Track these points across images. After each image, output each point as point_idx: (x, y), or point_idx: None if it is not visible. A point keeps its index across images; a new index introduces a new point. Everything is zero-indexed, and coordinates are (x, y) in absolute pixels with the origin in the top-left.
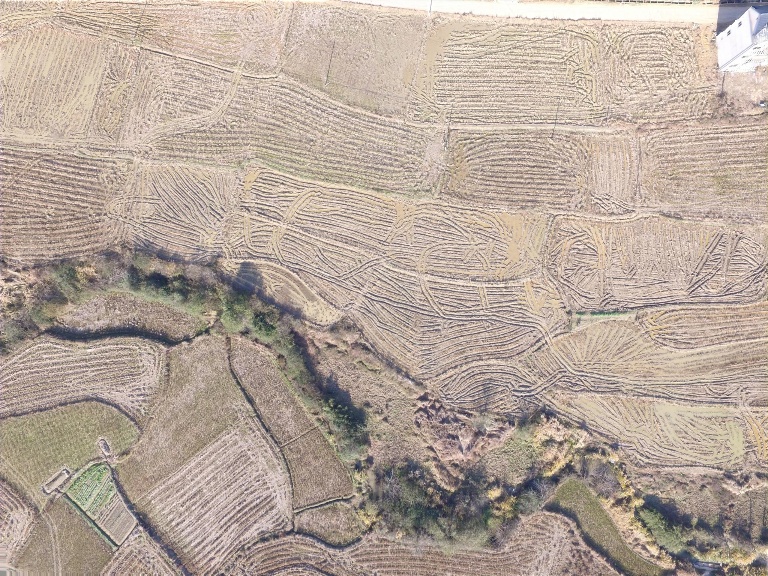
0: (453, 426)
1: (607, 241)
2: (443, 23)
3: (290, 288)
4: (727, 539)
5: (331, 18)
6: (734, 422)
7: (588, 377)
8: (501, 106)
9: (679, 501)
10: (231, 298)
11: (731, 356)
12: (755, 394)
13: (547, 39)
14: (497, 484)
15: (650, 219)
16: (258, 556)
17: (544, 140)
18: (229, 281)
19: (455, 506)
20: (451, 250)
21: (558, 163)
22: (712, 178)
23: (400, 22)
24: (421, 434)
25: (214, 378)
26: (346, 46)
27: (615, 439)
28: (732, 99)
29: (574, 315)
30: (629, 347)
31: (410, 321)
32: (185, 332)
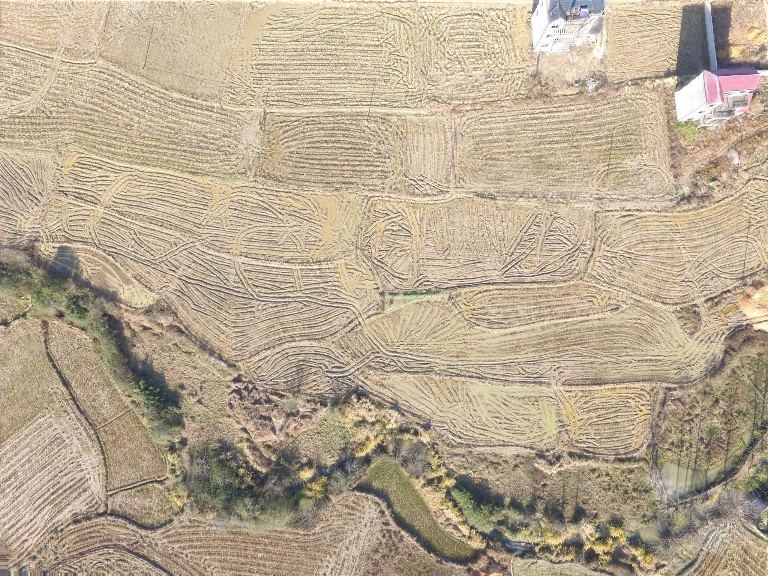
0: (265, 407)
1: (421, 222)
2: (261, 7)
3: (106, 271)
4: (540, 519)
5: (150, 3)
6: (547, 402)
7: (401, 358)
8: (317, 89)
9: (492, 481)
10: (47, 282)
11: (544, 336)
12: (568, 373)
13: (364, 22)
14: (309, 465)
15: (465, 200)
16: (70, 538)
17: (359, 122)
18: (46, 265)
19: (263, 487)
20: (266, 232)
21: (373, 145)
22: (527, 158)
23: (218, 7)
24: (234, 415)
25: (30, 361)
26: (164, 31)
27: (428, 419)
28: (546, 79)
29: (387, 296)
30: (443, 327)
31: (224, 303)
32: (3, 316)
